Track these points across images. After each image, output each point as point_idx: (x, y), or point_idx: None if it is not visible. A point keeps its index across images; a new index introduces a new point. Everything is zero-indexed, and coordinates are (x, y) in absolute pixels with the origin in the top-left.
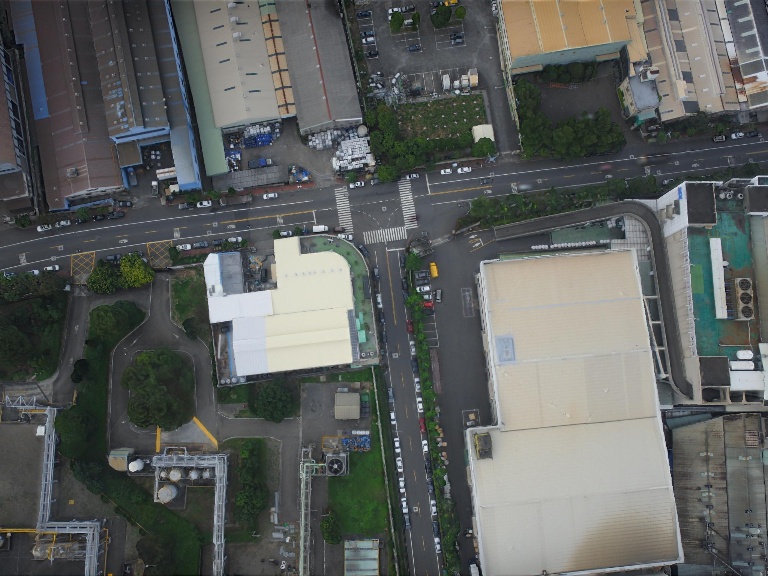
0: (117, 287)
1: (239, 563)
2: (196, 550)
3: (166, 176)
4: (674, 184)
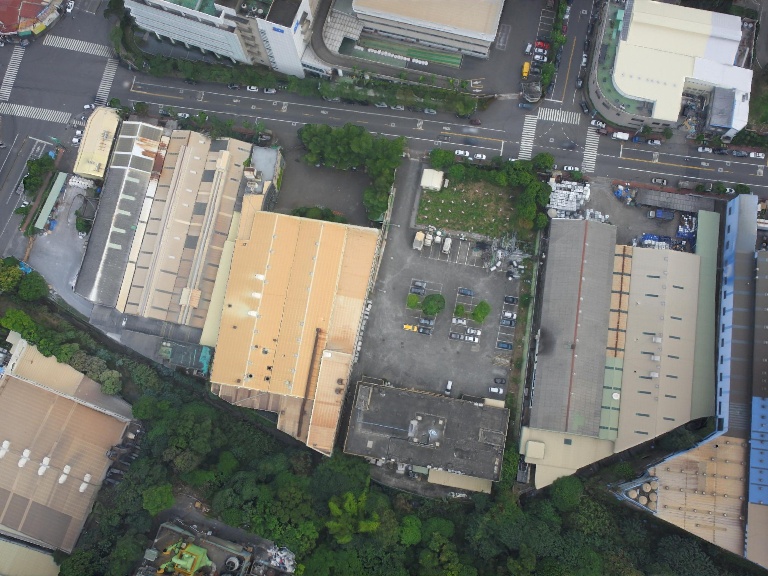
0: None
1: None
2: None
3: (763, 220)
4: (270, 81)
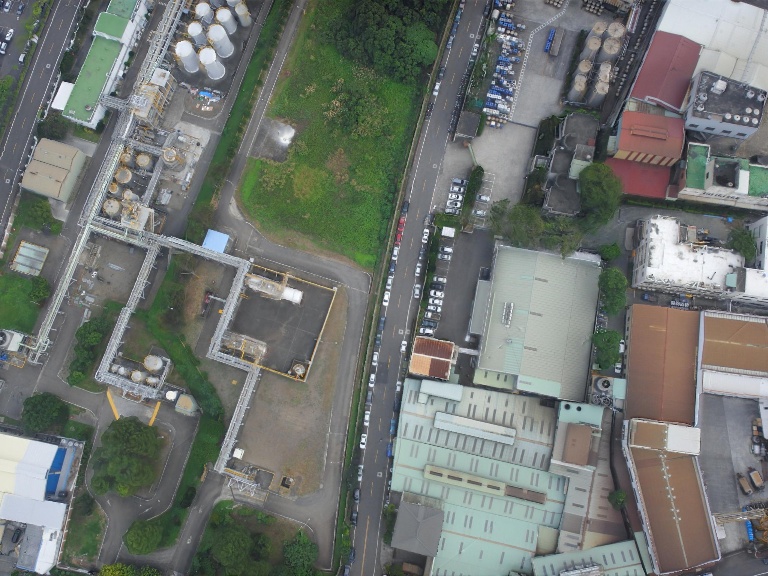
0: (140, 570)
1: (129, 288)
2: (152, 309)
3: None
4: None
